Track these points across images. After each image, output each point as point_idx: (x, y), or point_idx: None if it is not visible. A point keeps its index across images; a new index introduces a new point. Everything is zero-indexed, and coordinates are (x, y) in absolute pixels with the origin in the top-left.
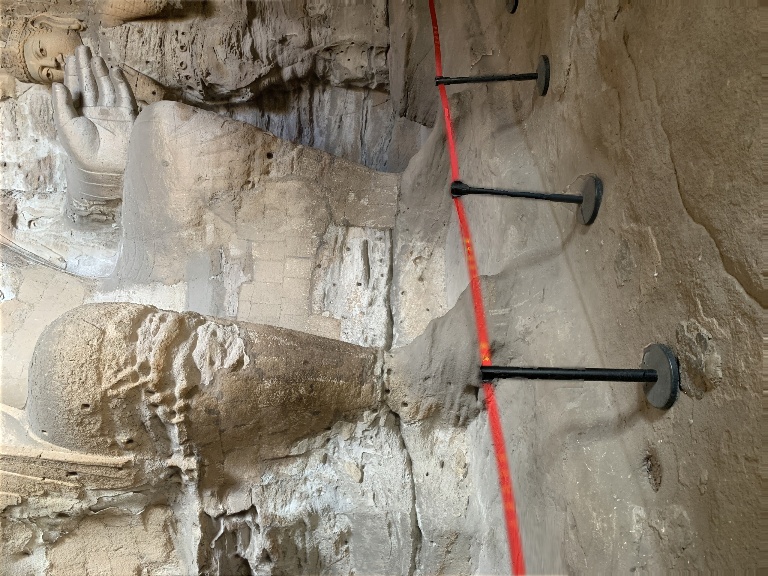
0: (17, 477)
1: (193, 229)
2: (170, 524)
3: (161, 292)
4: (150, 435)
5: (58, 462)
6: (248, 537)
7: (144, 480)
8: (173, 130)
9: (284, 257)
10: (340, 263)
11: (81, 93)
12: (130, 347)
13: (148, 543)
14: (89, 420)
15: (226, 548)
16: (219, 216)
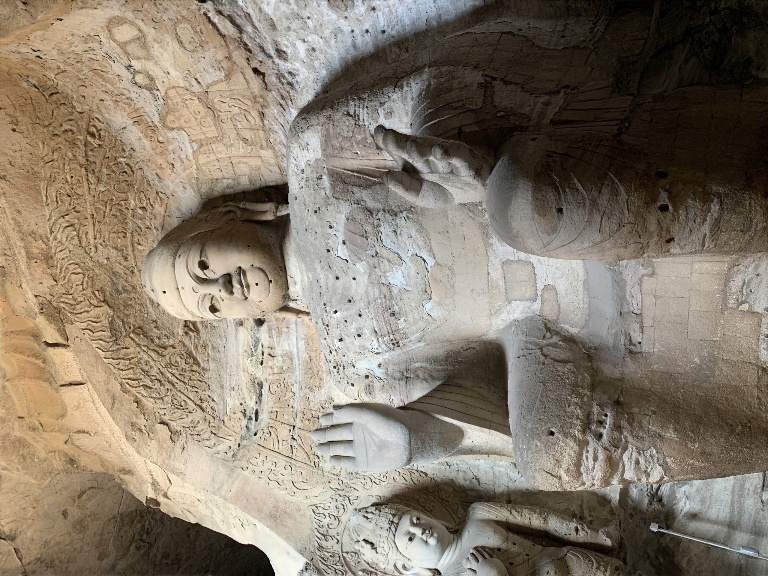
0: None
1: None
2: None
3: None
4: None
5: None
6: None
7: None
8: (542, 246)
9: (692, 262)
10: None
11: None
12: (579, 480)
13: None
14: None
15: None
16: None
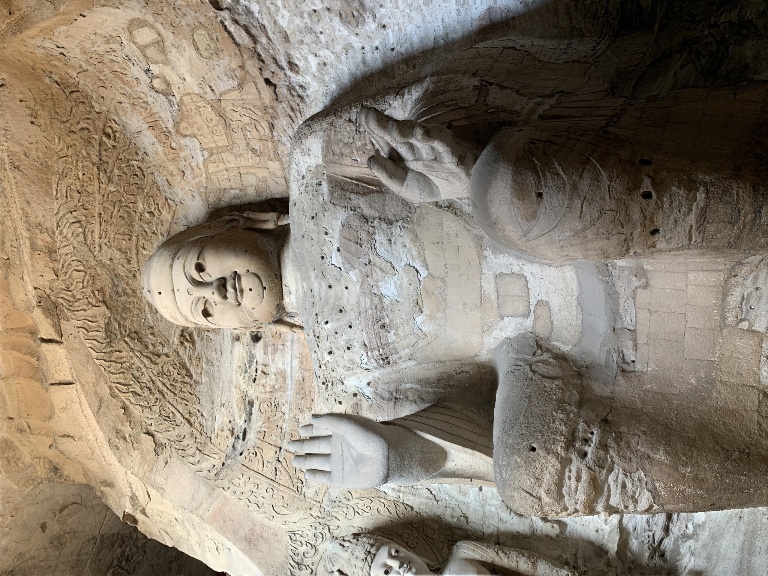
0: None
1: None
2: None
3: (549, 270)
4: None
5: None
6: None
7: None
8: (522, 235)
9: (686, 271)
10: (767, 271)
11: (394, 149)
12: (561, 504)
13: None
14: None
15: None
16: None
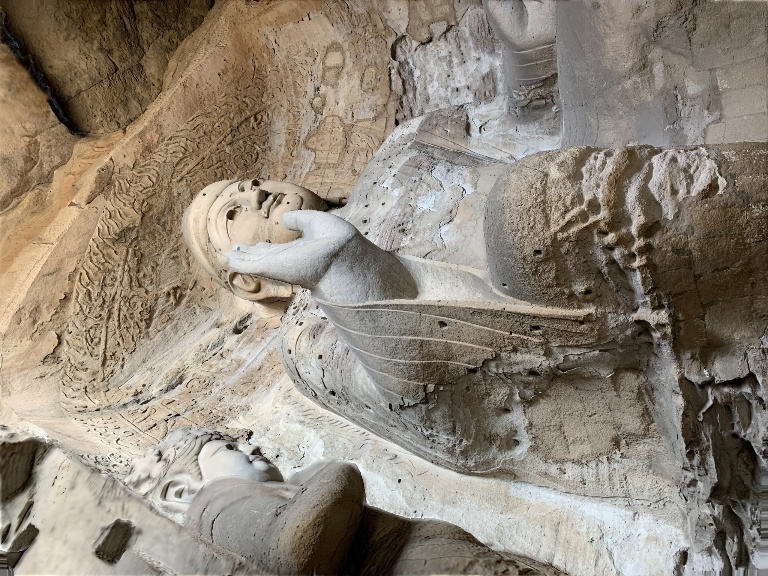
0: (488, 331)
1: (638, 75)
2: (645, 392)
3: None
4: (609, 285)
5: (521, 315)
6: (748, 414)
7: (609, 337)
8: None
9: (766, 77)
10: None
11: None
12: (575, 186)
13: (623, 412)
14: (543, 268)
15: (719, 424)
16: (668, 49)
